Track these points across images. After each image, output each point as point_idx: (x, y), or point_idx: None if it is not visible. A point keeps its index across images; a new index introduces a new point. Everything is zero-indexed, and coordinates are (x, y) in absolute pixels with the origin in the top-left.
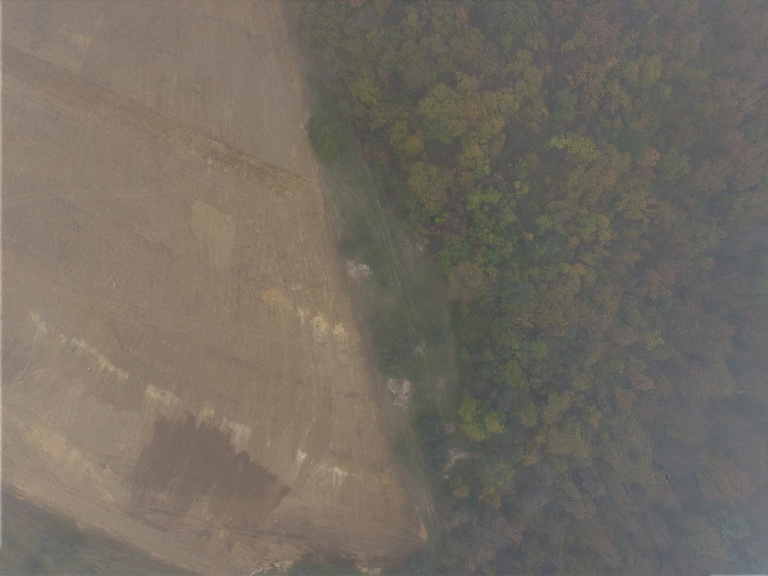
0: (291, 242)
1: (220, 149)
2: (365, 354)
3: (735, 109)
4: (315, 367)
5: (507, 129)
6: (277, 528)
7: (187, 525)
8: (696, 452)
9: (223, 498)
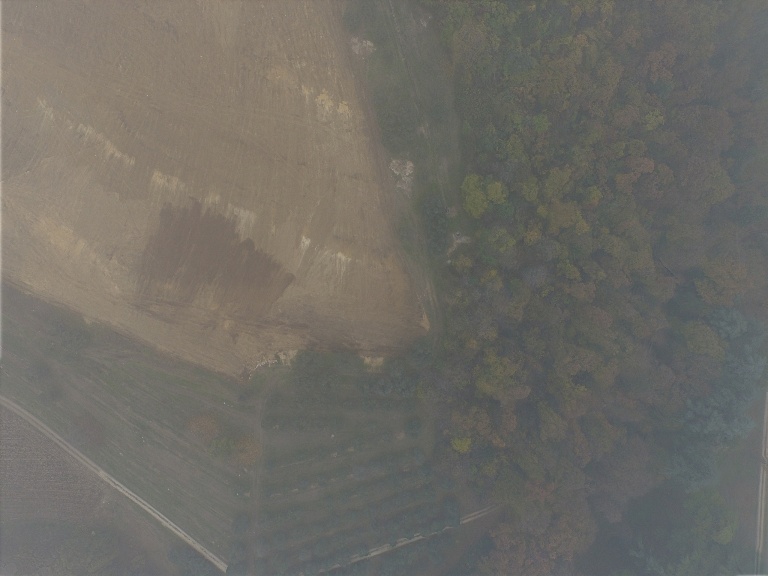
0: (296, 17)
1: None
2: (369, 133)
3: None
4: (319, 148)
5: None
6: (281, 318)
7: (193, 316)
8: (695, 256)
9: (228, 287)
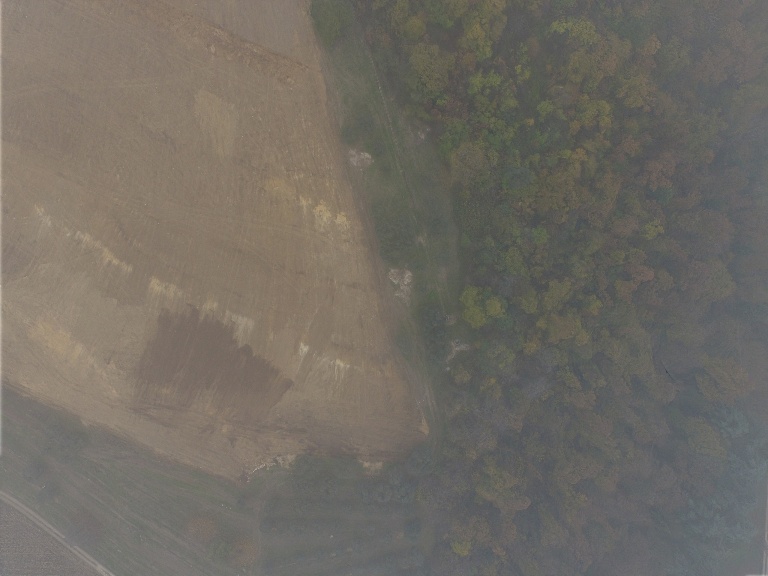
0: (293, 130)
1: (223, 37)
2: (367, 244)
3: (736, 0)
4: (317, 257)
5: (508, 11)
6: (280, 422)
7: (191, 420)
8: (696, 353)
9: (226, 392)
